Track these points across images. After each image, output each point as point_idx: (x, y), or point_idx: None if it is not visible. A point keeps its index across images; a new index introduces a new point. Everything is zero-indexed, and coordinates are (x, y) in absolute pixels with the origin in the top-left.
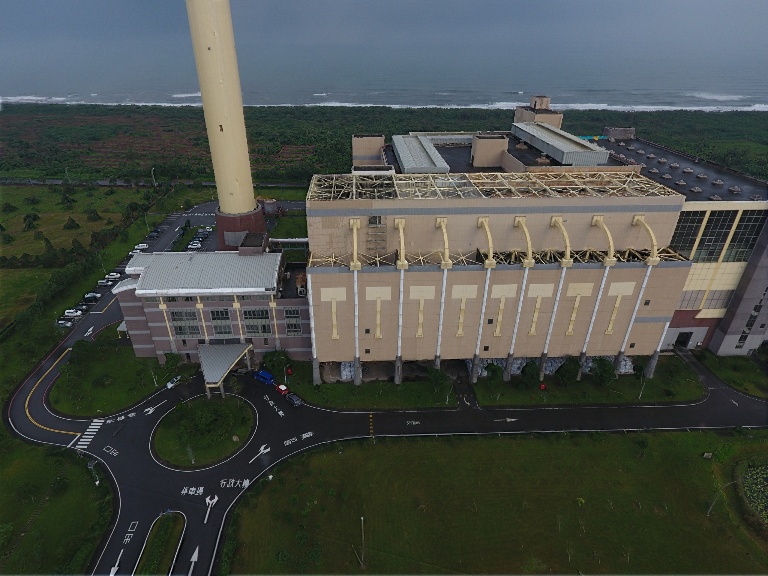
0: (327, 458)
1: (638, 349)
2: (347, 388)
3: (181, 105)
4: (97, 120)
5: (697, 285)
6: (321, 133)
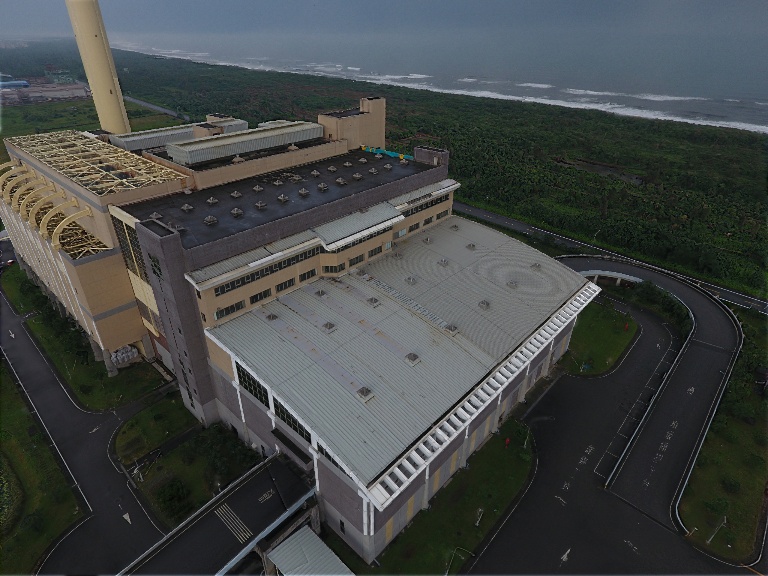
0: None
1: (96, 339)
2: (22, 277)
3: (421, 89)
4: (348, 94)
5: (155, 308)
6: None
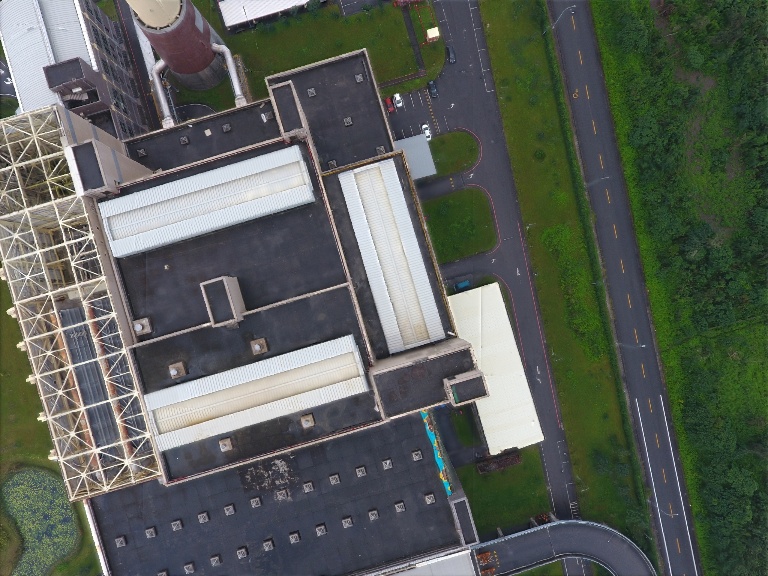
0: None
1: None
2: None
3: None
4: None
5: None
6: None
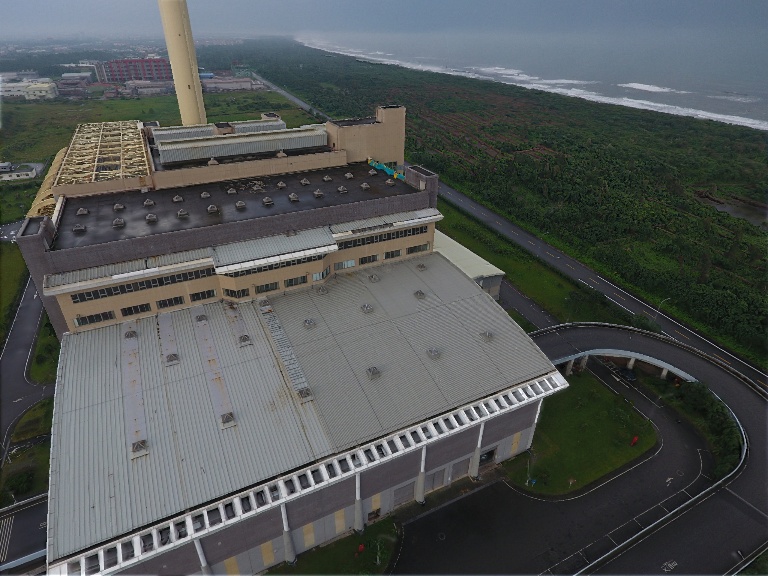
0: None
1: None
2: None
3: (574, 96)
4: (490, 98)
5: None
6: (613, 146)
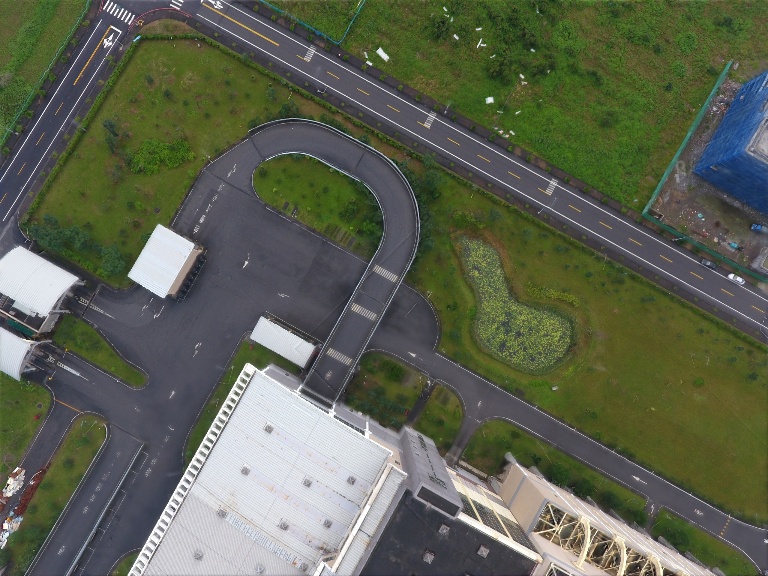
0: (766, 516)
1: None
2: (726, 569)
3: None
4: None
5: None
6: None
